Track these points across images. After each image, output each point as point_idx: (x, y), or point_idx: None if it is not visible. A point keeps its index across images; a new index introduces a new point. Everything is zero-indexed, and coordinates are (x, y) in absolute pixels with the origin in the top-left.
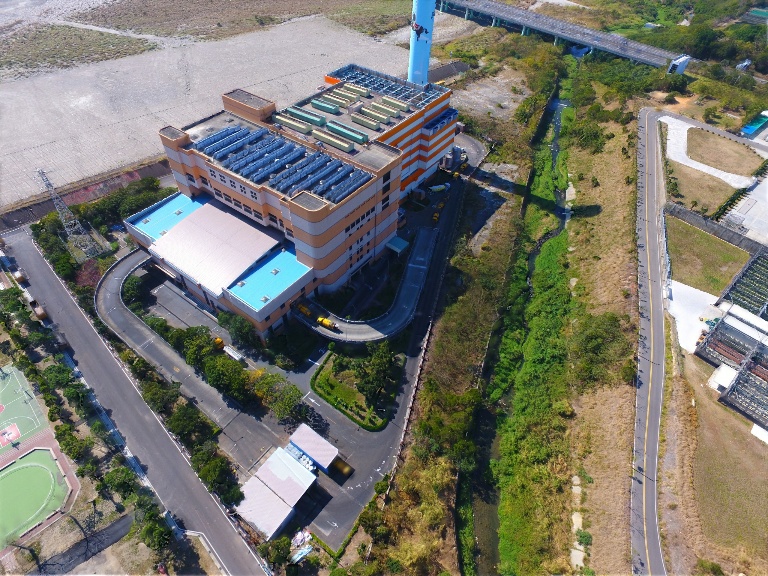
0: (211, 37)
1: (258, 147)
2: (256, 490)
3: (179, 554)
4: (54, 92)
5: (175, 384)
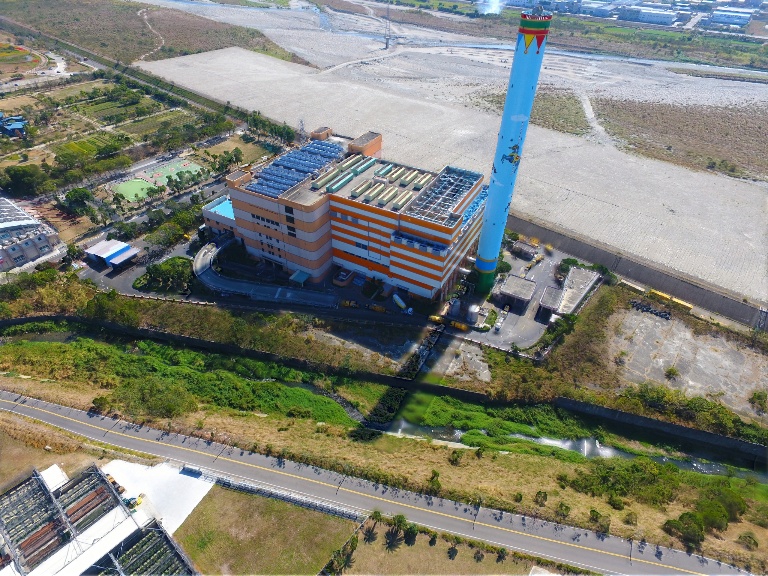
0: (635, 150)
1: (318, 158)
2: (110, 243)
3: (95, 232)
4: (469, 122)
5: (180, 208)
